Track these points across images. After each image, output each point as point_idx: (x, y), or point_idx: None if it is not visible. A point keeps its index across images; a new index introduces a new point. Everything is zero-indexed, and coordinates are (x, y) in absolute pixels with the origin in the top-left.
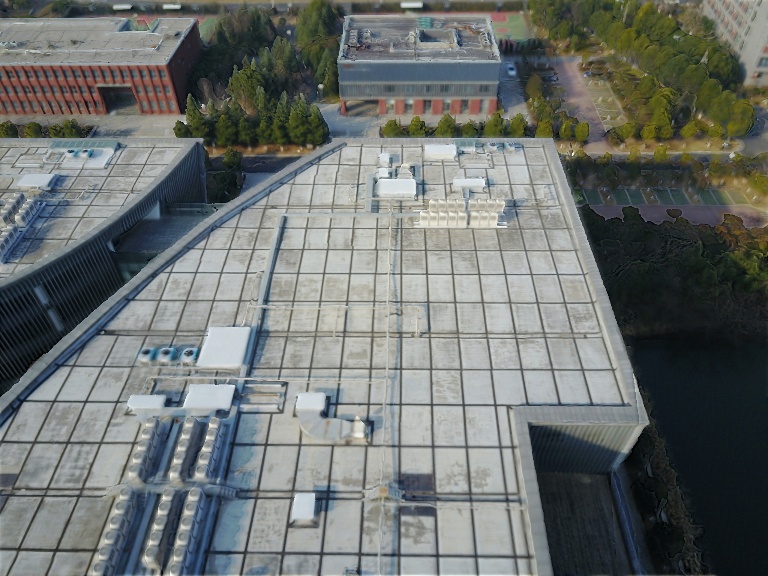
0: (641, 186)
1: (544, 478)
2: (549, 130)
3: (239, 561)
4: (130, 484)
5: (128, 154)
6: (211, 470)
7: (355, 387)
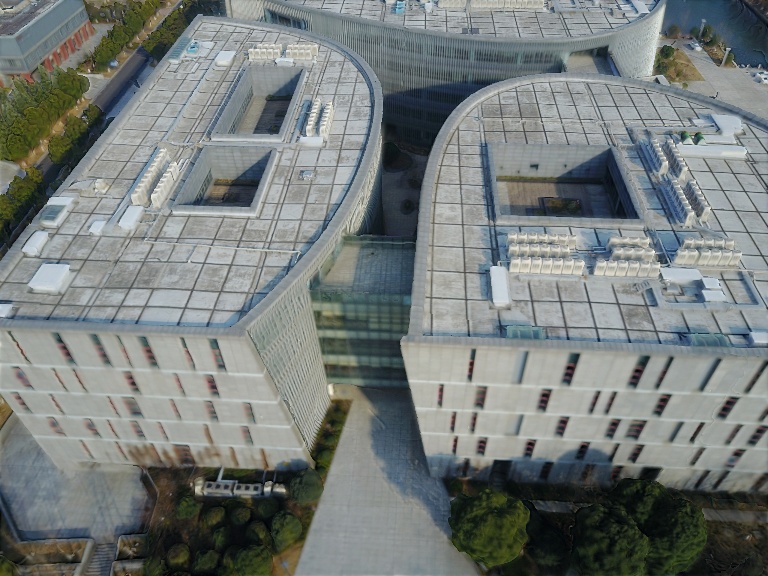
0: (211, 7)
1: None
2: (151, 7)
3: None
4: None
5: (200, 37)
6: None
7: None
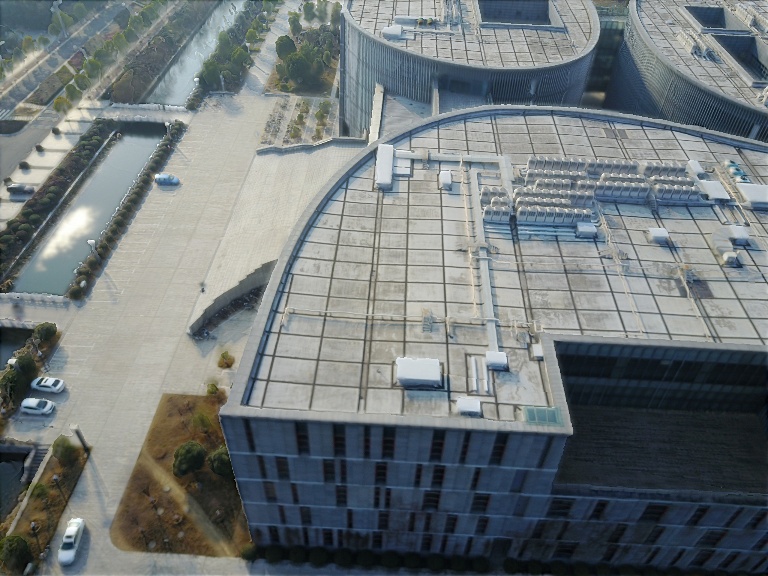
0: None
1: (764, 441)
2: None
3: (615, 213)
4: (640, 165)
5: None
6: (664, 196)
7: (767, 259)
